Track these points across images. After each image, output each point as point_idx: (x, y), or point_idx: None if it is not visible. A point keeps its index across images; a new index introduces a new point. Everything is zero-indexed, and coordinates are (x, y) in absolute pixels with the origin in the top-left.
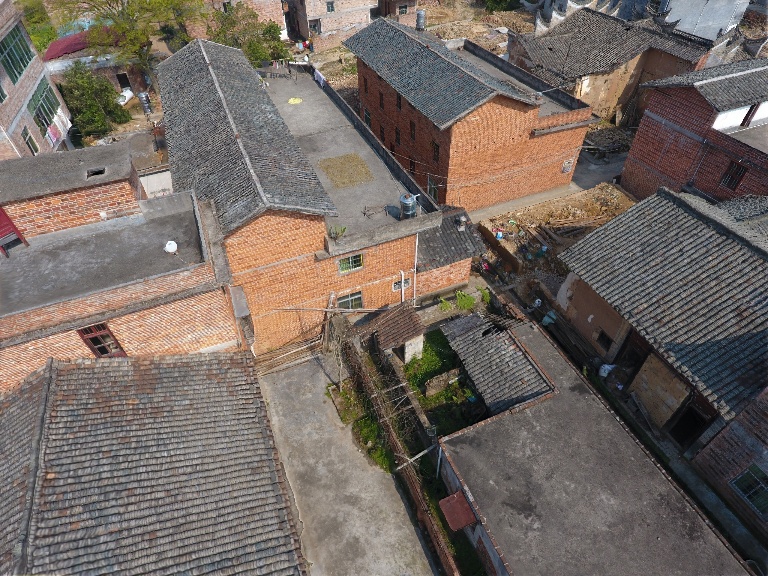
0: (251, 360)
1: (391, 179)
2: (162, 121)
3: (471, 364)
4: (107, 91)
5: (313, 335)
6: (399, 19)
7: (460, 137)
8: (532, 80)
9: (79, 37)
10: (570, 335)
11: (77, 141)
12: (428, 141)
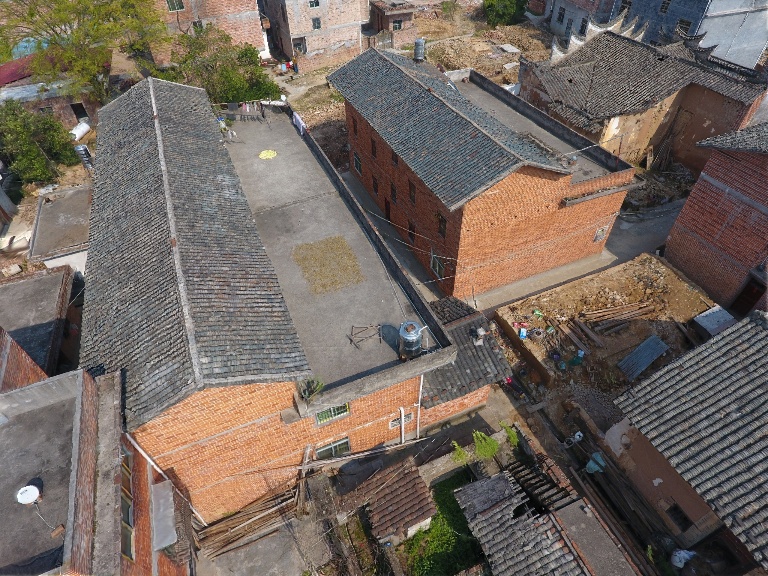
0: None
1: (386, 279)
2: None
3: (500, 566)
4: (52, 130)
5: (285, 489)
6: (393, 35)
7: (474, 214)
8: (555, 126)
9: (15, 68)
10: (626, 494)
11: (15, 190)
12: (432, 210)
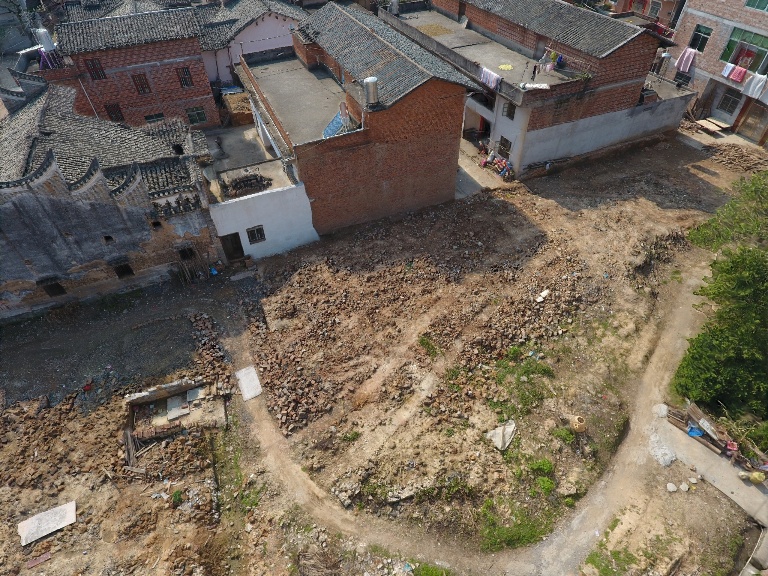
0: None
1: None
2: (649, 88)
3: None
4: None
5: None
6: None
7: None
8: None
9: None
10: None
11: None
12: None
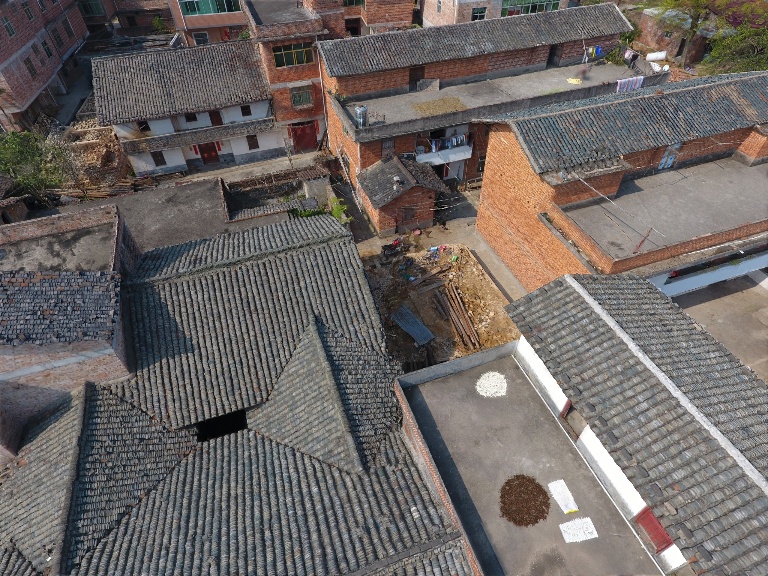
0: (266, 97)
1: None
2: None
3: None
4: None
5: None
6: None
7: None
8: None
9: None
10: None
11: None
12: None
